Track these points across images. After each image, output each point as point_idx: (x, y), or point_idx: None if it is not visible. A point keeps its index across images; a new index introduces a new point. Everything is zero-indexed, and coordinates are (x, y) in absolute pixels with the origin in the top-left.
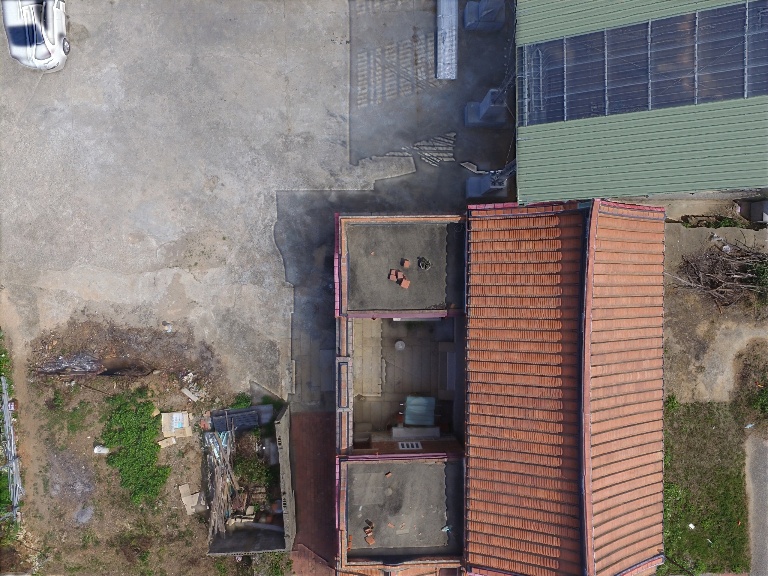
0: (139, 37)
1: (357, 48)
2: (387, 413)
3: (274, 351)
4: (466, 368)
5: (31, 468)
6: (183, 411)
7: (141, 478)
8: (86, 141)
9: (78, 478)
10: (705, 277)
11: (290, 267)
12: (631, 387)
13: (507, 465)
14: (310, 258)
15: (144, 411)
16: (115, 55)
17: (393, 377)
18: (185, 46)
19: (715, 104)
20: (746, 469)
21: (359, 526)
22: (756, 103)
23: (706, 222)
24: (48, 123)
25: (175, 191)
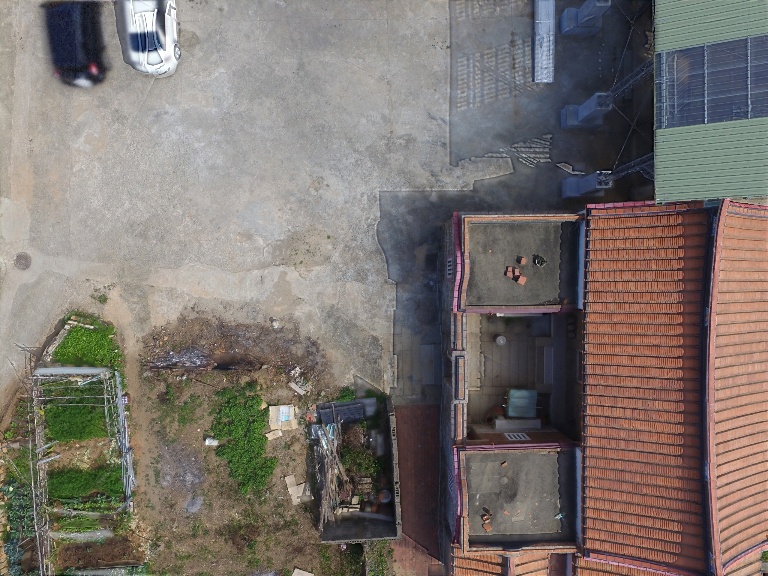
0: (247, 43)
1: (457, 53)
2: (485, 406)
3: (377, 346)
4: (583, 361)
5: (143, 460)
6: (289, 404)
7: (249, 469)
8: (196, 143)
9: (188, 469)
10: None
11: (392, 265)
12: (744, 379)
13: (626, 454)
14: (412, 256)
15: (253, 404)
16: (224, 60)
17: (491, 371)
18: (291, 51)
19: None
20: None
21: (477, 513)
22: None
23: None
24: (159, 126)
25: (281, 192)
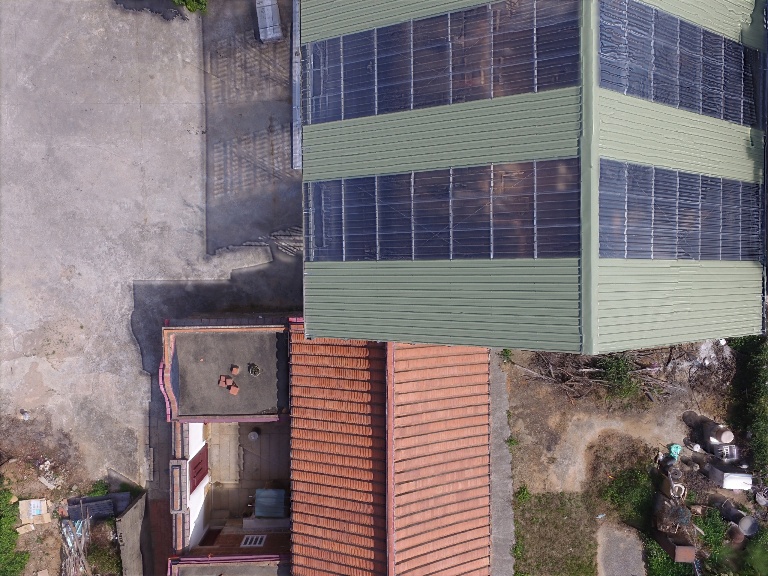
0: None
1: (213, 138)
2: (245, 500)
3: (132, 439)
4: None
5: None
6: (41, 498)
7: None
8: None
9: None
10: (556, 370)
11: (147, 356)
12: (451, 498)
13: (326, 575)
14: None
15: (1, 499)
16: None
17: (251, 464)
18: (41, 136)
19: (466, 262)
20: (598, 558)
21: None
22: (500, 265)
23: None
24: None
25: (32, 280)
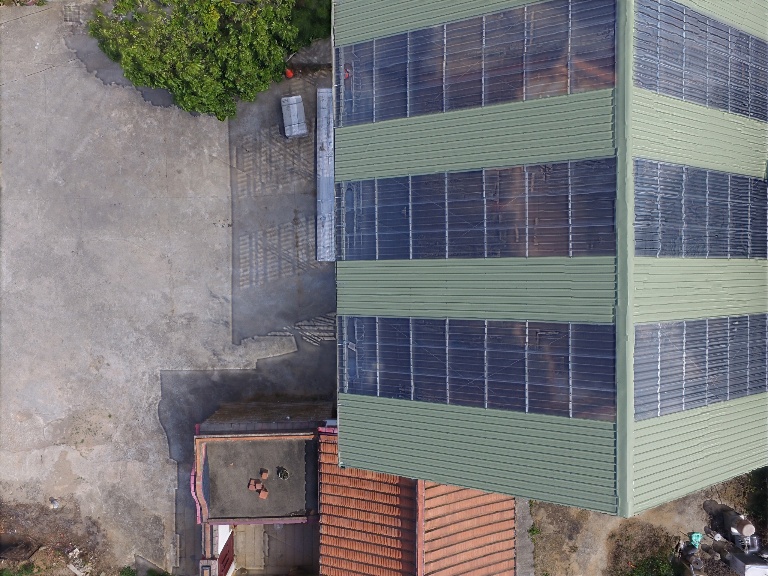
0: (26, 222)
1: (239, 231)
2: None
3: (159, 526)
4: None
5: None
6: None
7: None
8: None
9: None
10: None
11: (174, 444)
12: None
13: None
14: None
15: None
16: (2, 239)
17: (275, 550)
18: (71, 230)
19: (501, 412)
20: None
21: None
22: (536, 419)
23: None
24: None
25: (62, 370)
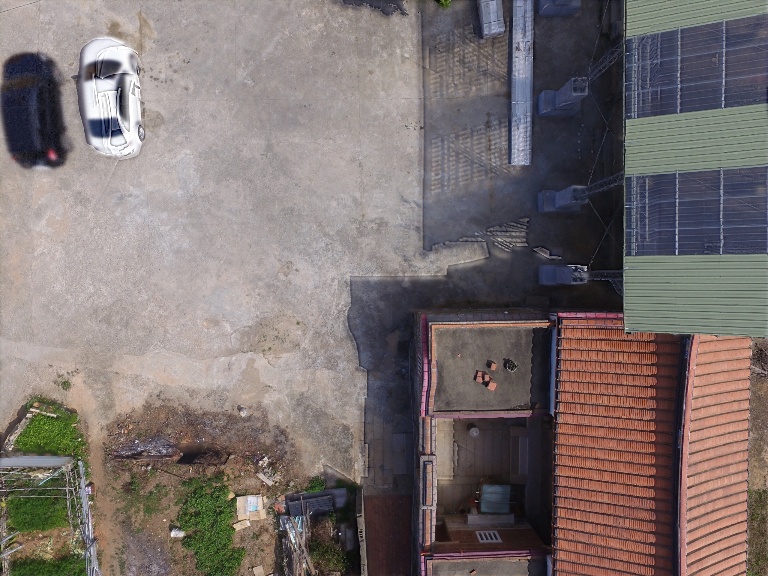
0: (214, 123)
1: (431, 134)
2: (459, 496)
3: (347, 435)
4: (554, 472)
5: (107, 550)
6: (257, 494)
7: (216, 560)
8: (161, 227)
9: (154, 560)
10: None
11: (364, 352)
12: (719, 493)
13: (596, 571)
14: (383, 343)
15: (220, 495)
16: (190, 141)
17: (465, 460)
18: (260, 132)
19: None
20: None
21: None
22: None
23: None
24: (124, 209)
25: (249, 276)
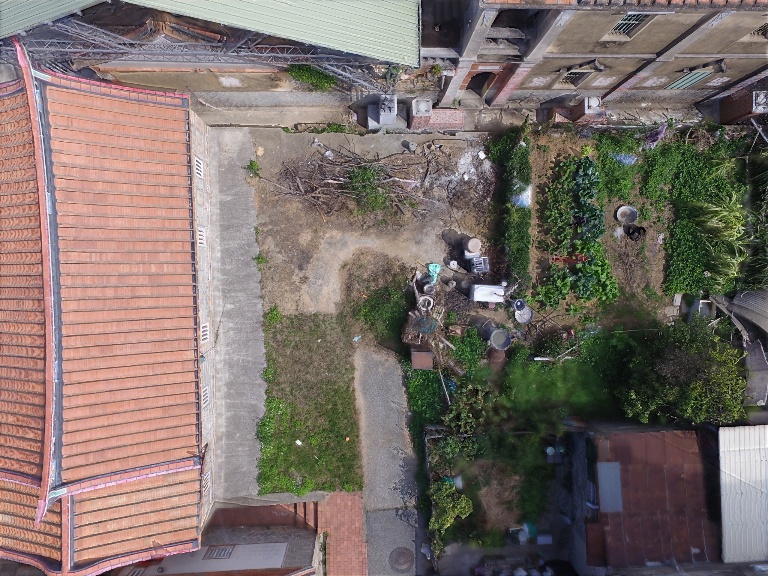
0: None
1: None
2: None
3: None
4: None
5: None
6: None
7: None
8: None
9: None
10: (304, 183)
11: None
12: (141, 279)
13: (7, 360)
14: None
15: None
16: None
17: None
18: None
19: None
20: (355, 383)
21: None
22: None
23: (313, 128)
24: None
25: None
